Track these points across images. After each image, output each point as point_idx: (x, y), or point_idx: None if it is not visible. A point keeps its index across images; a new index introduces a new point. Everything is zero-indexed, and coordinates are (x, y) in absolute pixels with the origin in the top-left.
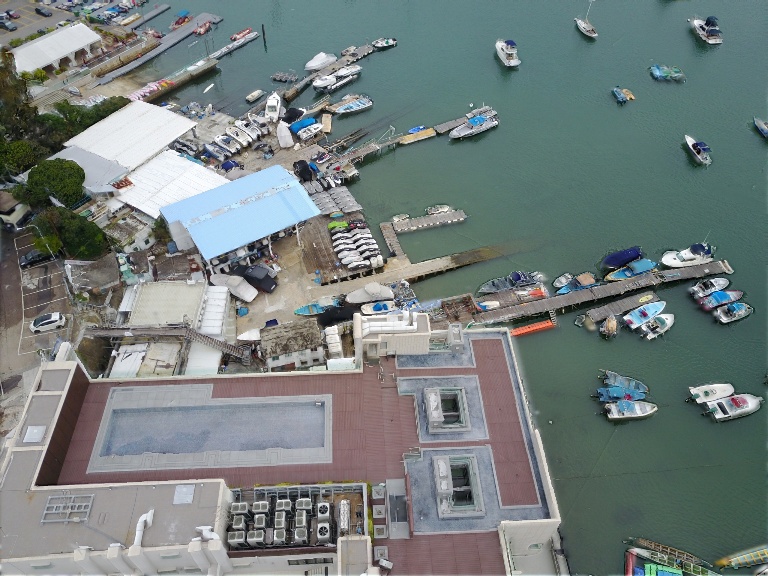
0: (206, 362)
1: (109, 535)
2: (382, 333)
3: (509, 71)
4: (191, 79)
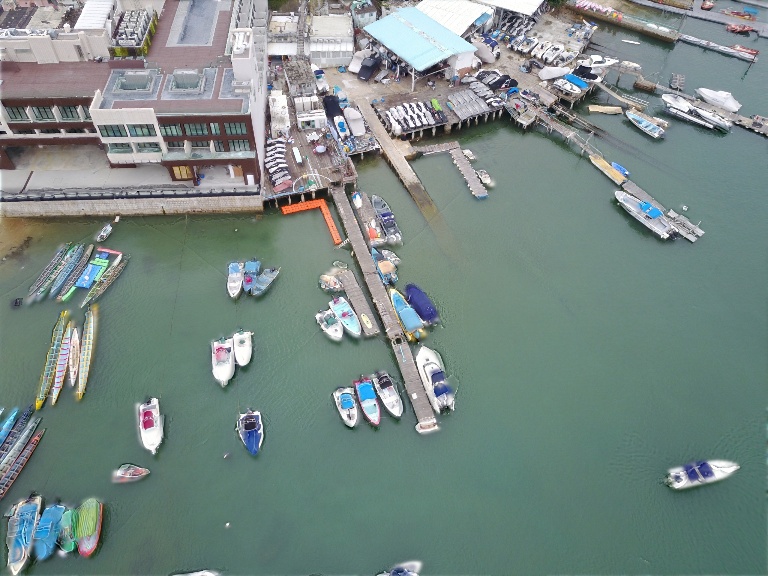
0: (289, 50)
1: None
2: None
3: None
4: (641, 32)
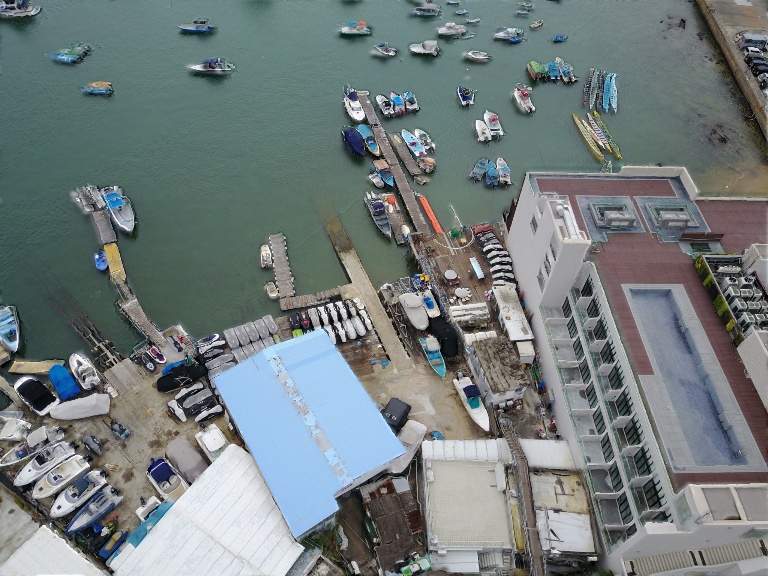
0: (534, 452)
1: None
2: None
3: None
4: None
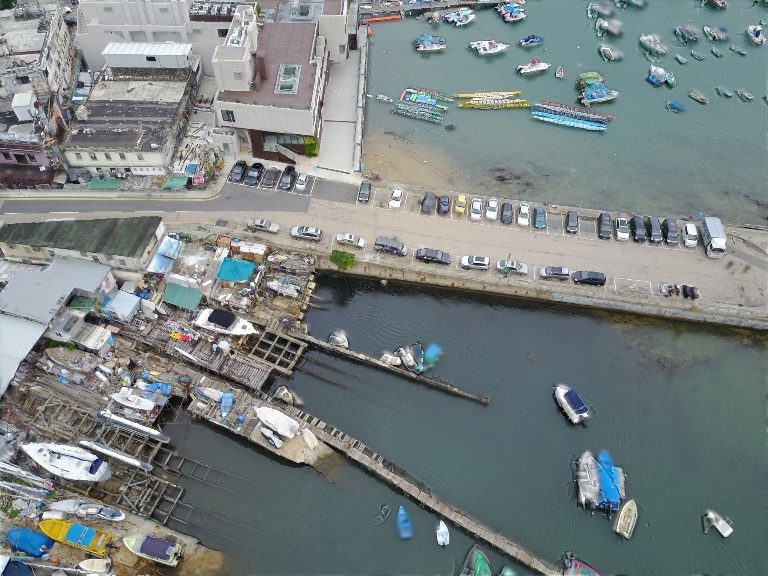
0: None
1: None
2: None
3: None
4: None
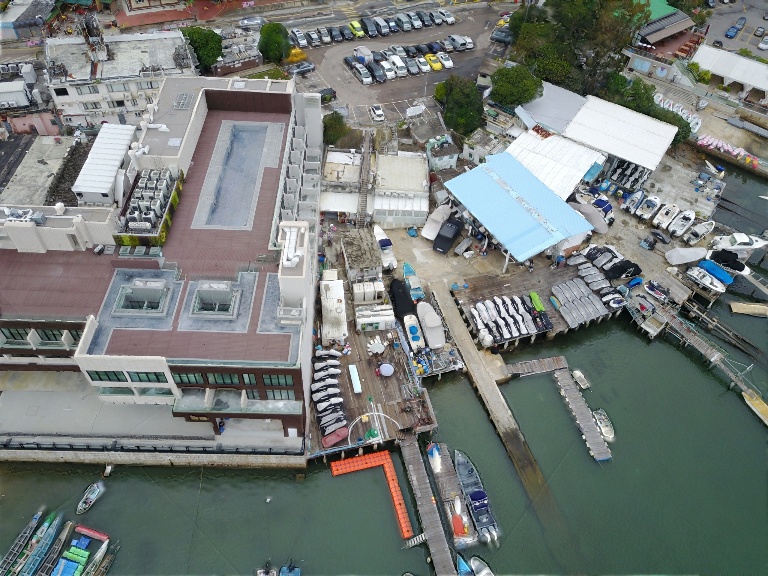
0: (347, 204)
1: (162, 117)
2: None
3: None
4: None
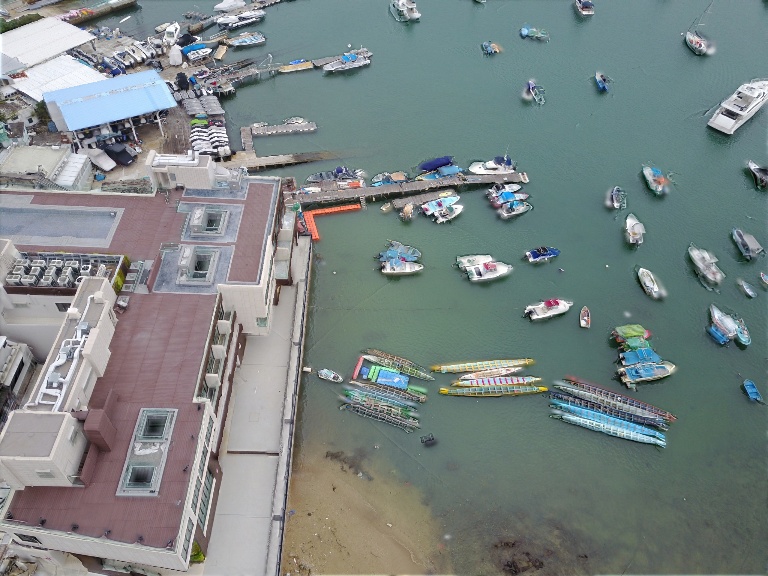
0: None
1: None
2: (169, 165)
3: (400, 26)
4: (112, 11)
